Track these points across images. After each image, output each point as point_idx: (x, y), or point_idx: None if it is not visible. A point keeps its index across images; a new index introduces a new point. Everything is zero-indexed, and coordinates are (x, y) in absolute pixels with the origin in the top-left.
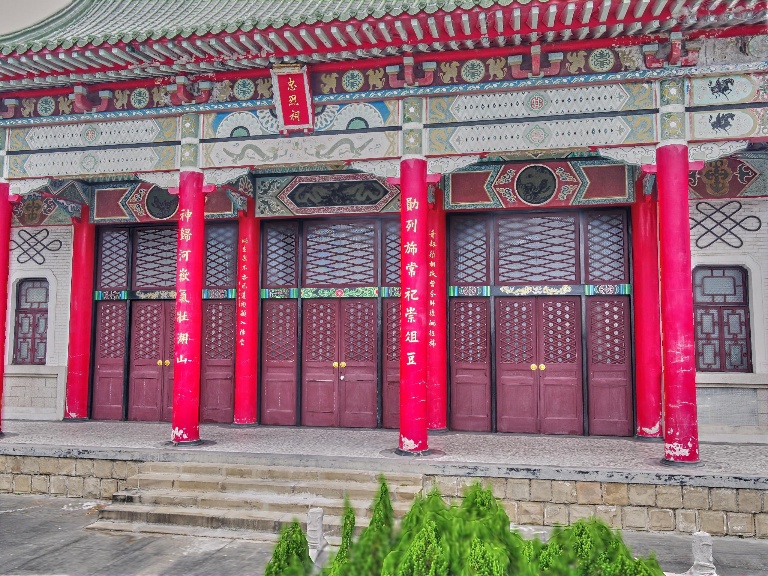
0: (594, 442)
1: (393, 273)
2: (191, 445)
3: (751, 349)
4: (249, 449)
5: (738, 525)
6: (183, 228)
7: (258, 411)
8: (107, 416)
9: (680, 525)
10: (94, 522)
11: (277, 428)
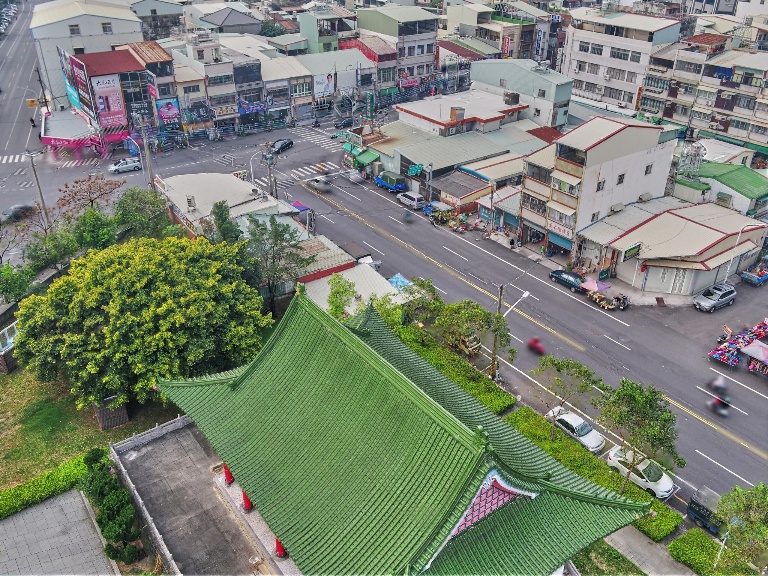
0: None
1: None
2: (280, 557)
3: None
4: (288, 572)
5: None
6: None
7: None
8: None
9: None
10: None
11: None
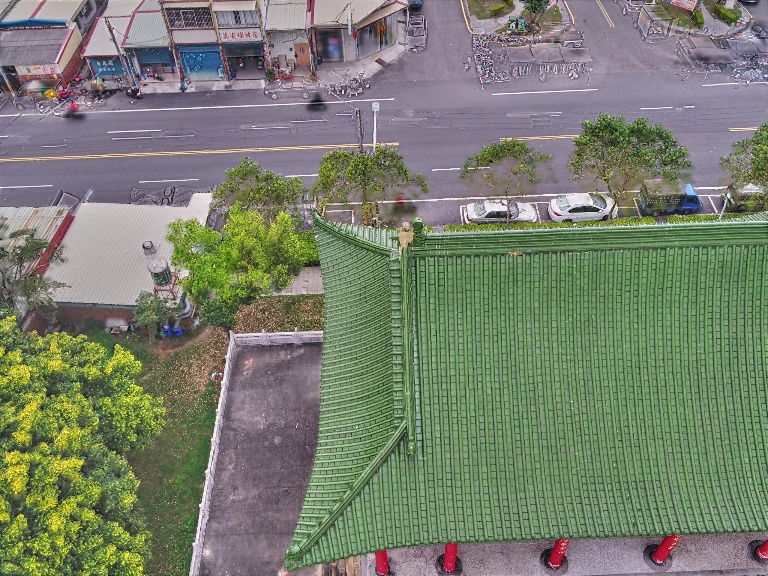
0: None
1: None
2: (560, 567)
3: None
4: (590, 568)
5: None
6: None
7: None
8: None
9: None
10: None
11: None
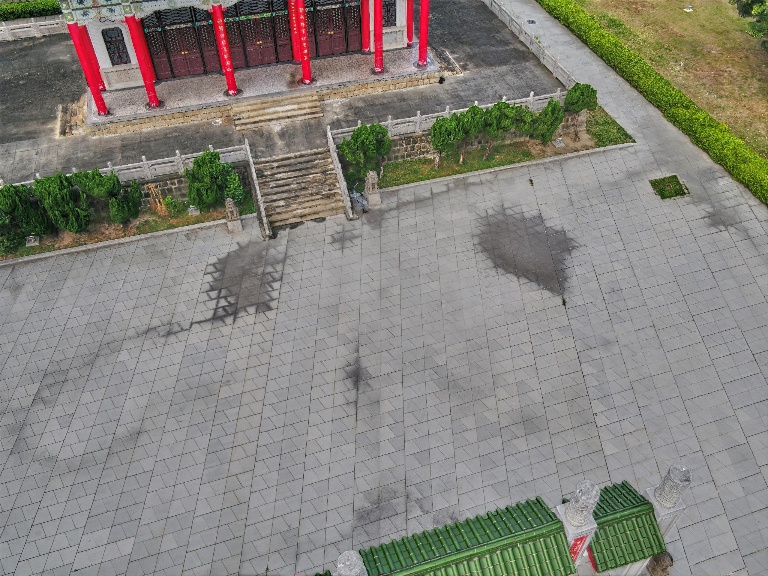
0: (352, 59)
1: (276, 6)
2: (238, 94)
3: (396, 18)
4: (259, 92)
5: (392, 88)
6: (220, 26)
7: None
8: (165, 77)
9: (379, 90)
10: (236, 128)
11: (242, 71)
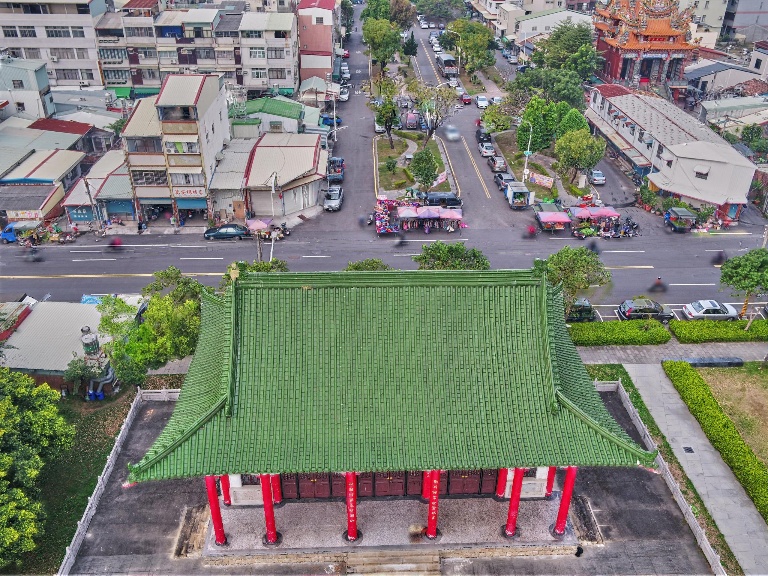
0: (483, 505)
1: None
2: (357, 540)
3: (536, 471)
4: (379, 541)
5: (522, 554)
6: (350, 488)
7: (357, 494)
8: (290, 497)
9: (507, 555)
10: None
11: (368, 502)
